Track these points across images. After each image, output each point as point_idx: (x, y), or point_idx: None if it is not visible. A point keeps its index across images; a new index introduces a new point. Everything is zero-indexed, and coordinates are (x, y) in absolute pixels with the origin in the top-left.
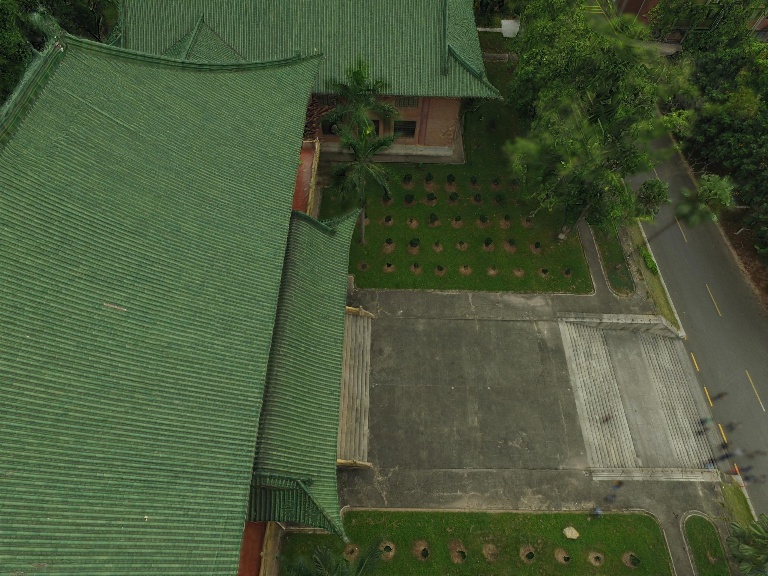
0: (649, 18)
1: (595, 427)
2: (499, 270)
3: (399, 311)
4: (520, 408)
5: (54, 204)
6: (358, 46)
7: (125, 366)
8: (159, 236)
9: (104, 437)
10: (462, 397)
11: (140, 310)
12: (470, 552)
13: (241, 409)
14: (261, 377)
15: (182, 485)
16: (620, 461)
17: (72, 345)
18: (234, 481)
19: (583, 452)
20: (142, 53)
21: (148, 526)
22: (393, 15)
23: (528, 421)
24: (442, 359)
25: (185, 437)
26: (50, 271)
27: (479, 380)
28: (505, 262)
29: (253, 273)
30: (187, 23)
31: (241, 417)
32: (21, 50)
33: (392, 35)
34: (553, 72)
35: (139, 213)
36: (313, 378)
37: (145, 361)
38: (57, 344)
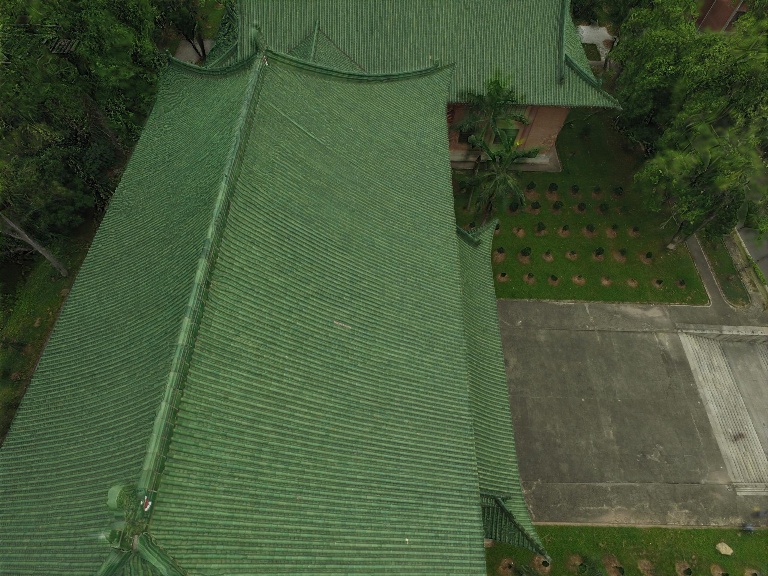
0: (738, 26)
1: (730, 441)
2: (612, 280)
3: (518, 321)
4: (653, 421)
5: (282, 221)
6: (473, 54)
7: (361, 385)
8: (360, 251)
9: (359, 458)
10: (594, 409)
11: (361, 327)
12: (626, 567)
13: (458, 427)
14: (467, 394)
15: (427, 506)
16: (758, 475)
17: (318, 364)
18: (467, 501)
19: (723, 466)
20: (320, 65)
21: (410, 549)
22: (509, 23)
23: (663, 434)
24: (568, 370)
25: (420, 457)
26: (291, 289)
27: (608, 392)
28: (617, 272)
29: (439, 288)
30: (302, 30)
31: (460, 436)
32: (156, 58)
33: (507, 43)
34: (698, 84)
35: (342, 228)
36: (486, 393)
37: (374, 380)
38: (308, 364)
